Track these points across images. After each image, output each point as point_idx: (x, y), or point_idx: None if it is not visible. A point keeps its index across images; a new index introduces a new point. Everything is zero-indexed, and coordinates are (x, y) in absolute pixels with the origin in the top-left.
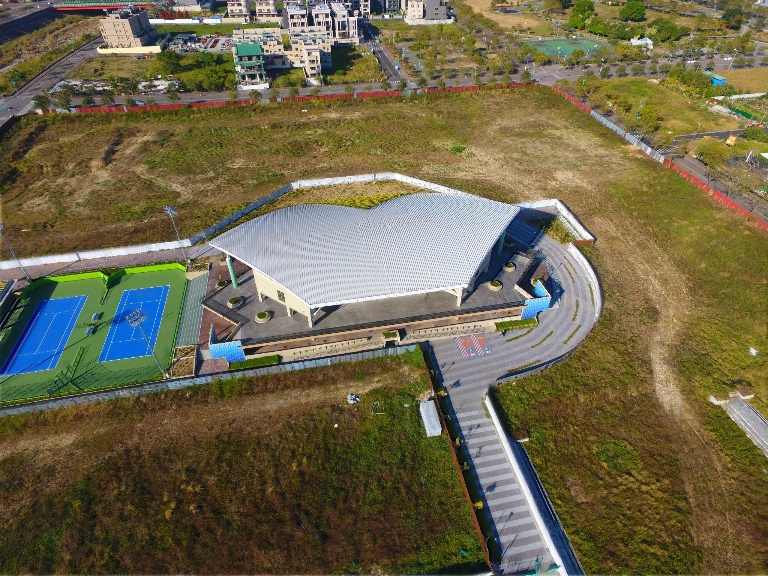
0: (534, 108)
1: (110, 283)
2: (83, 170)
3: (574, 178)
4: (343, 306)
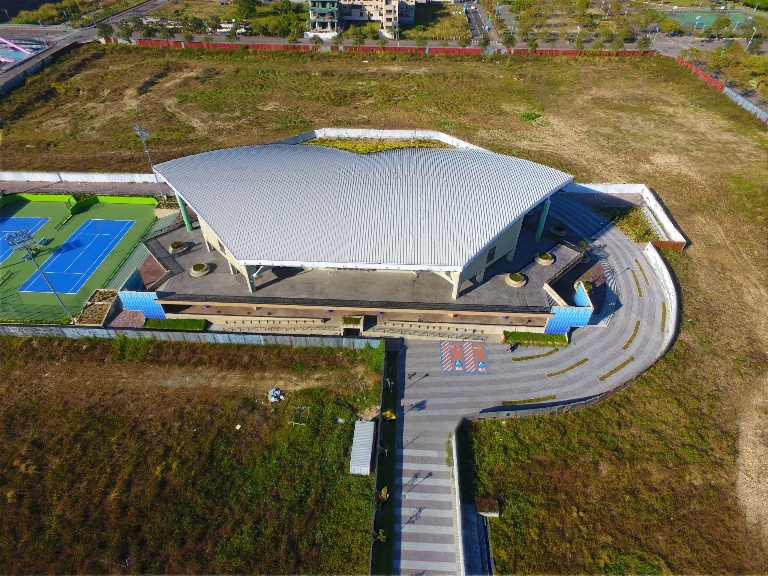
0: (646, 80)
1: (78, 209)
2: (116, 97)
3: (678, 164)
4: (303, 273)
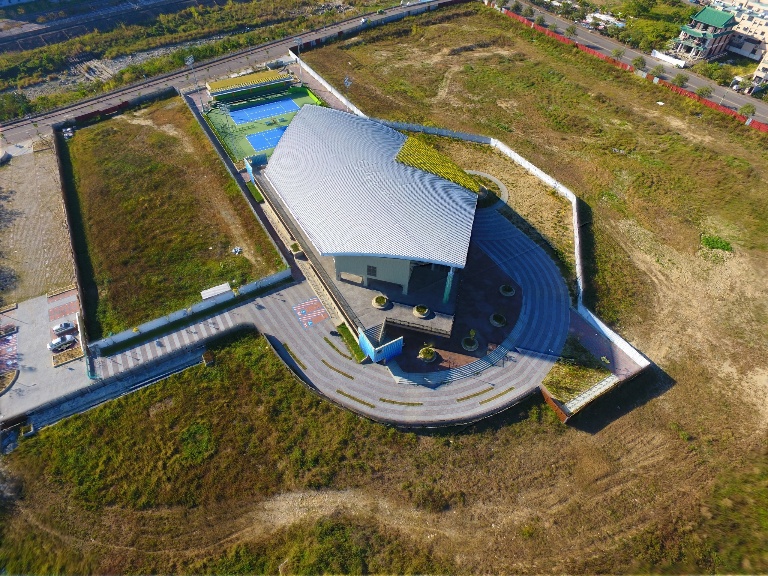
0: None
1: None
2: (434, 51)
3: None
4: None
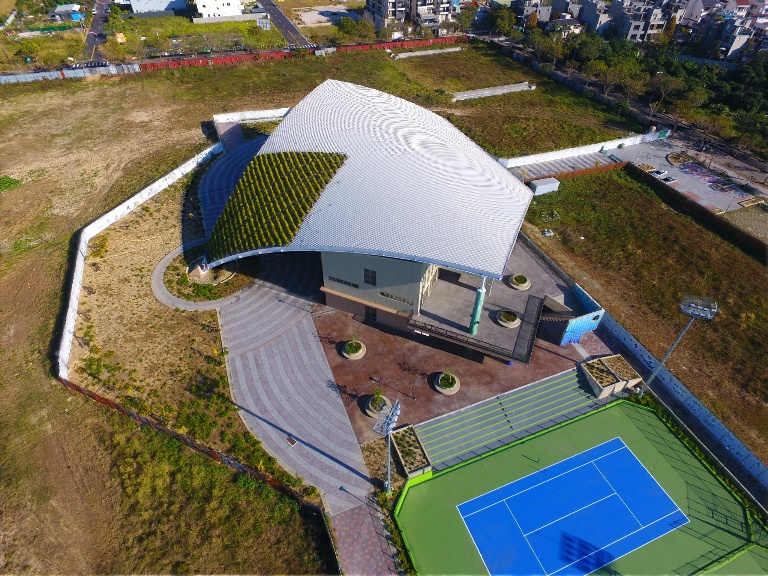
0: None
1: None
2: None
3: (151, 112)
4: None
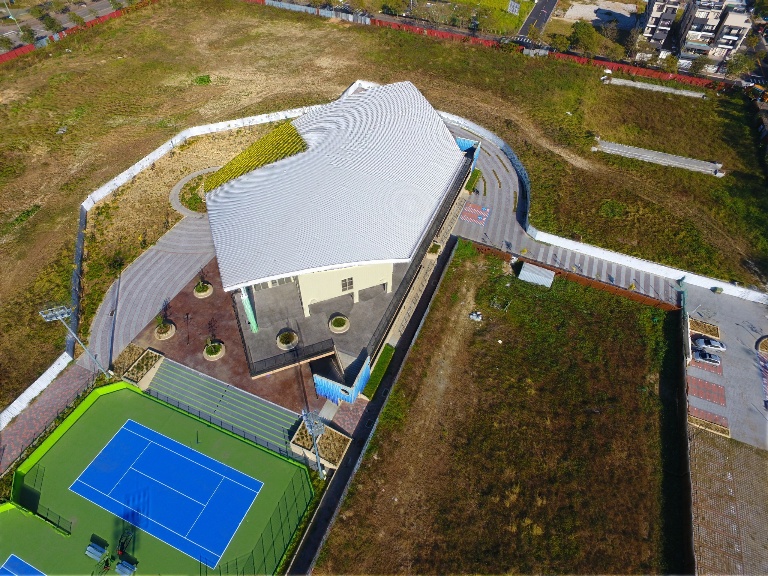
0: (208, 15)
1: None
2: None
3: (335, 61)
4: None
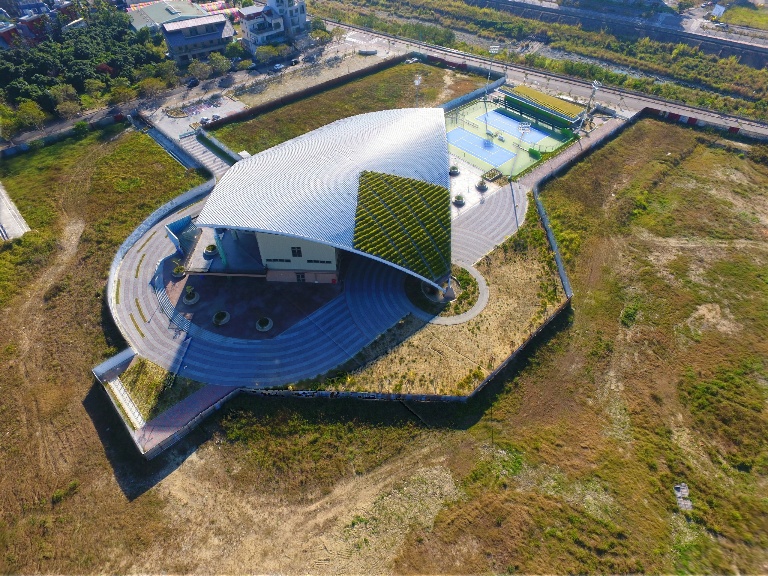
0: None
1: (535, 154)
2: None
3: None
4: None
